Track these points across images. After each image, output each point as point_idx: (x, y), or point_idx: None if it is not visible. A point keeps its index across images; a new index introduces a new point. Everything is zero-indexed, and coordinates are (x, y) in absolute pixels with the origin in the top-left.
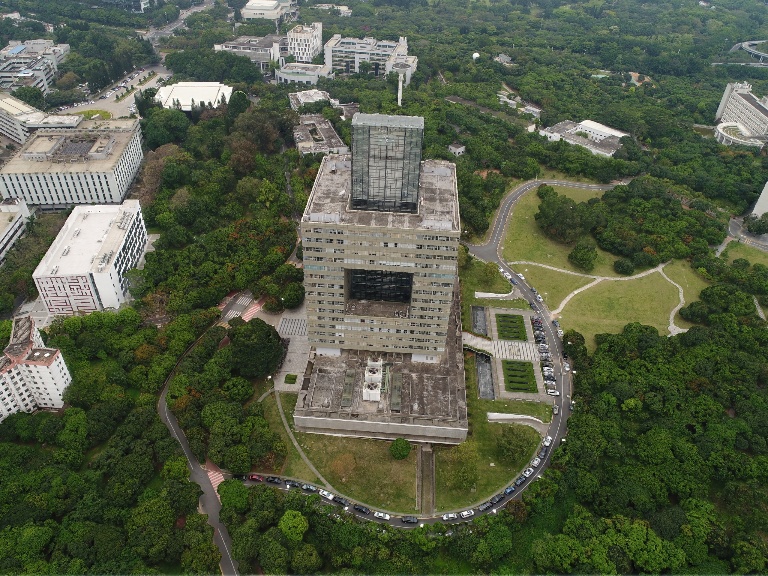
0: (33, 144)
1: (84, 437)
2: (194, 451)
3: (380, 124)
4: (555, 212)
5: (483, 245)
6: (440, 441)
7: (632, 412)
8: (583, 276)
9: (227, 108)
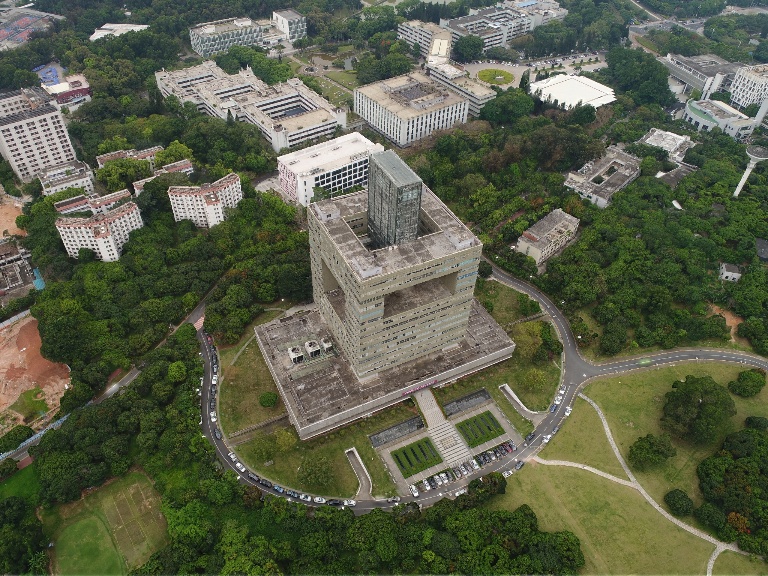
0: (396, 79)
1: (187, 252)
2: (206, 300)
3: (383, 166)
4: (684, 392)
5: (588, 363)
6: (294, 422)
7: (430, 566)
8: (622, 466)
9: (570, 115)
